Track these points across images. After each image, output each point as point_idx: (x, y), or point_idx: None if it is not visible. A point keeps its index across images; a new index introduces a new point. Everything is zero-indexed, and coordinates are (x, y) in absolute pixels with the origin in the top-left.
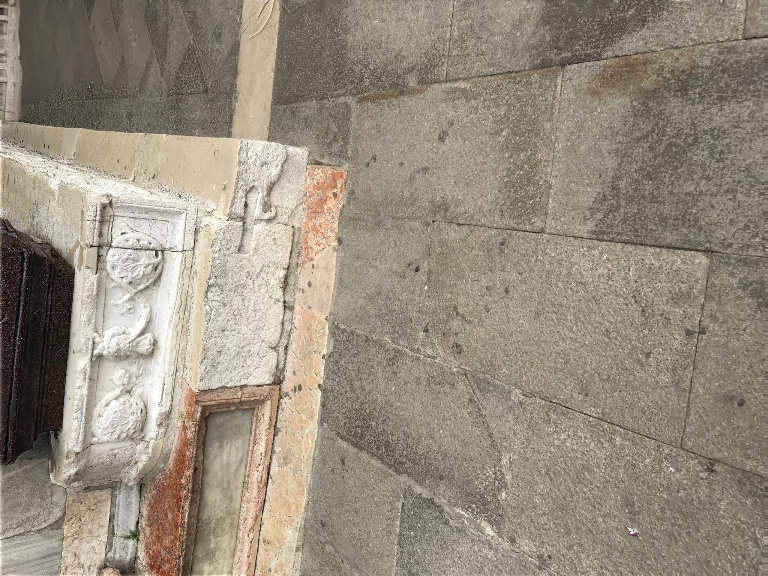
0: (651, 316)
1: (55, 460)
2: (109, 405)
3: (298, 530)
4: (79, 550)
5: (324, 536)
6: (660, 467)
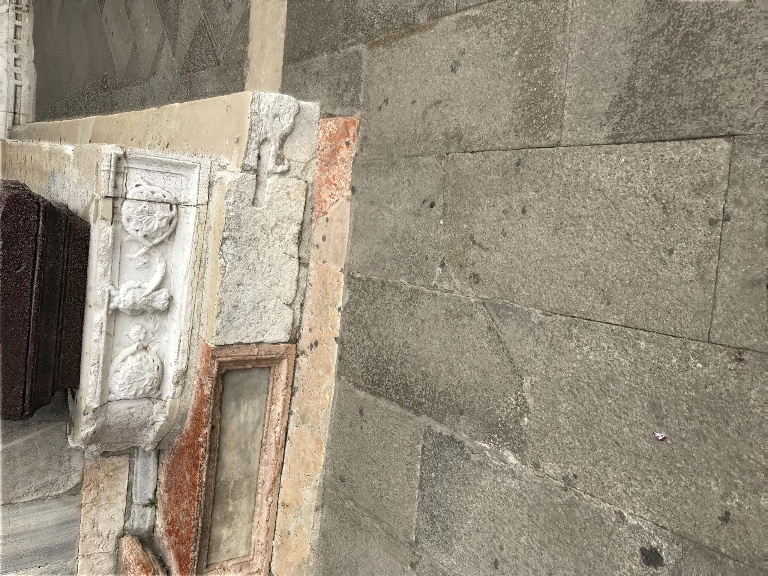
0: (673, 211)
1: (73, 420)
2: (126, 360)
3: (317, 489)
4: (98, 517)
5: (343, 492)
6: (687, 365)
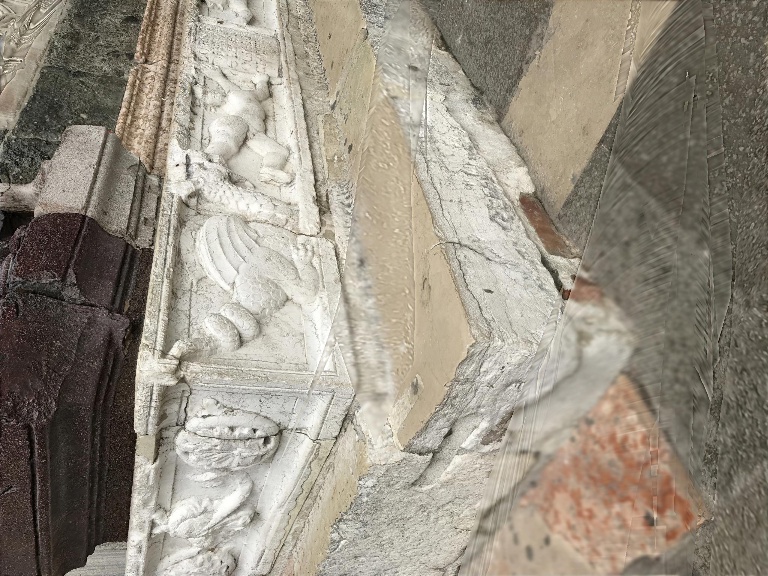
0: None
1: None
2: (181, 561)
3: None
4: None
5: None
6: None
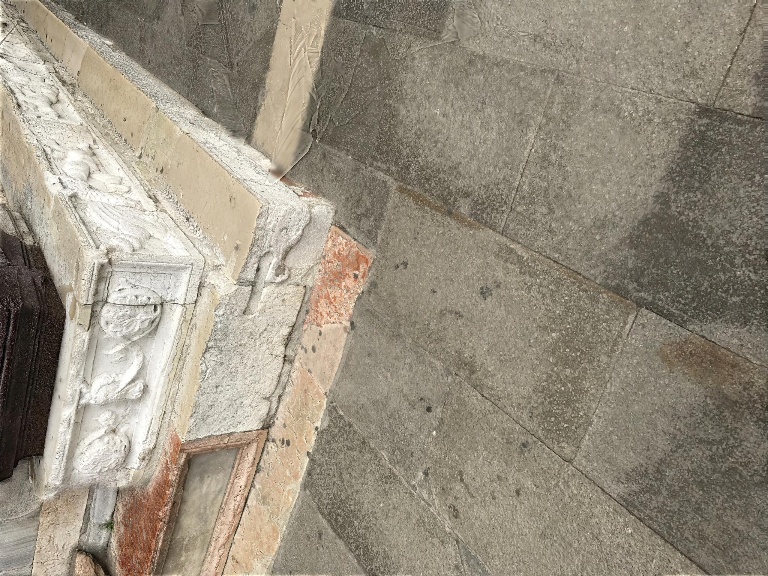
0: None
1: (35, 472)
2: (92, 443)
3: (267, 567)
4: (54, 533)
5: None
6: None
